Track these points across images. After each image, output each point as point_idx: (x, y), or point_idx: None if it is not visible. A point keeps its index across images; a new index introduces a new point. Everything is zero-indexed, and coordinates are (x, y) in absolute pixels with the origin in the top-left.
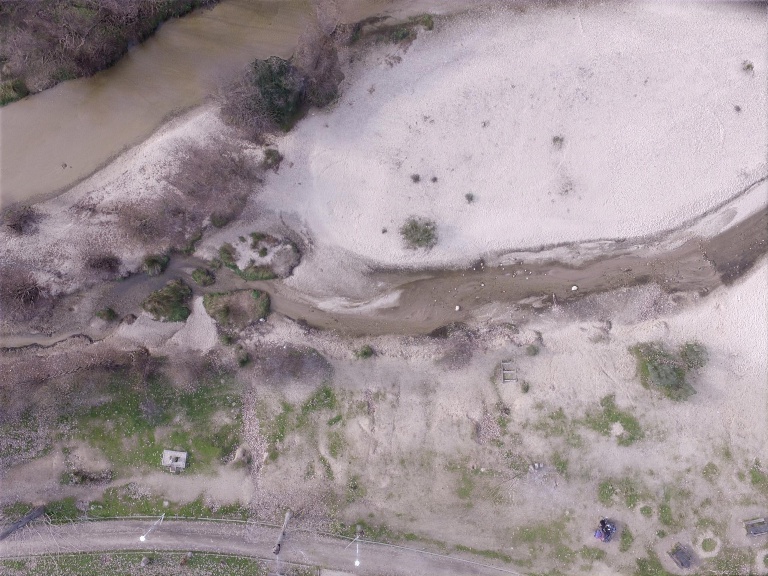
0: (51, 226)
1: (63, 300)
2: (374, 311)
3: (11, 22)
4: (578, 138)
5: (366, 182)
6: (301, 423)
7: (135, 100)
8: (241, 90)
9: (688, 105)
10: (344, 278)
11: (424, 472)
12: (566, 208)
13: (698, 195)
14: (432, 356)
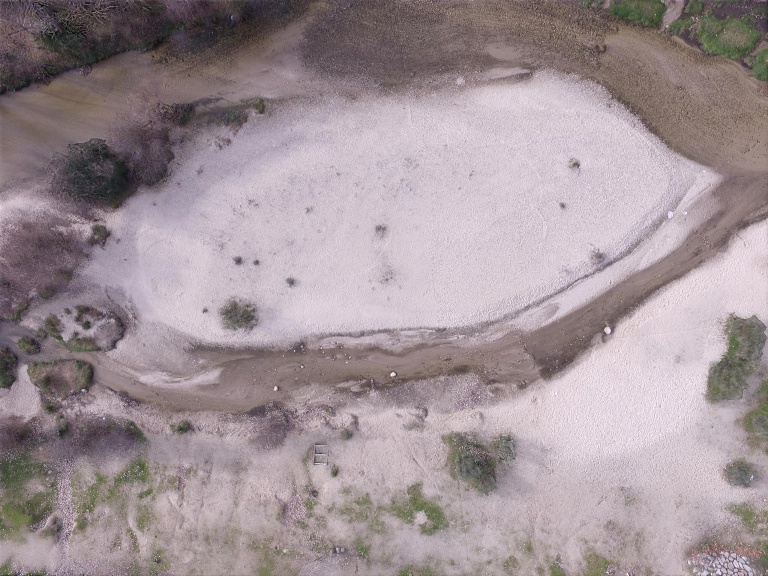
0: None
1: None
2: (194, 387)
3: None
4: (400, 228)
5: (189, 261)
6: (112, 495)
7: None
8: None
9: (512, 200)
10: (166, 353)
11: (228, 550)
12: (386, 296)
13: (518, 290)
14: (248, 434)
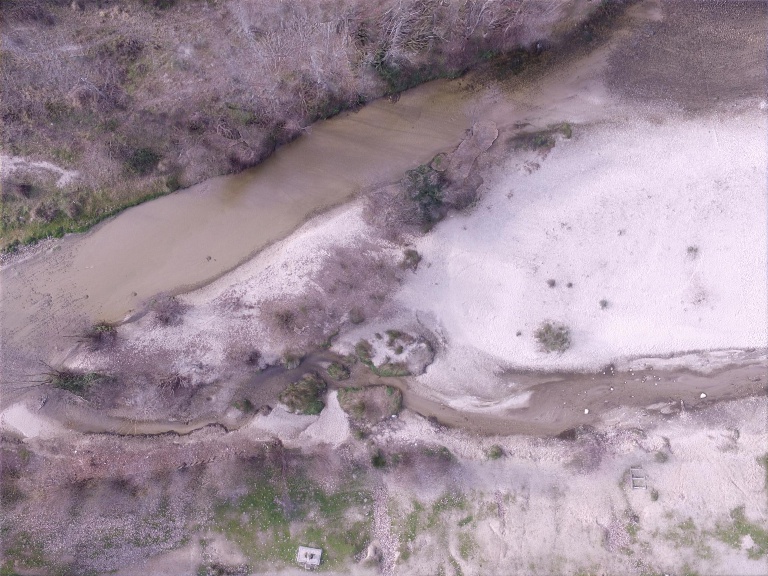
0: (195, 317)
1: (202, 389)
2: (504, 411)
3: (168, 121)
4: (712, 249)
5: (502, 285)
6: (432, 523)
7: (280, 197)
8: (382, 191)
9: None
10: (476, 378)
11: None
12: (698, 317)
13: None
14: (561, 459)
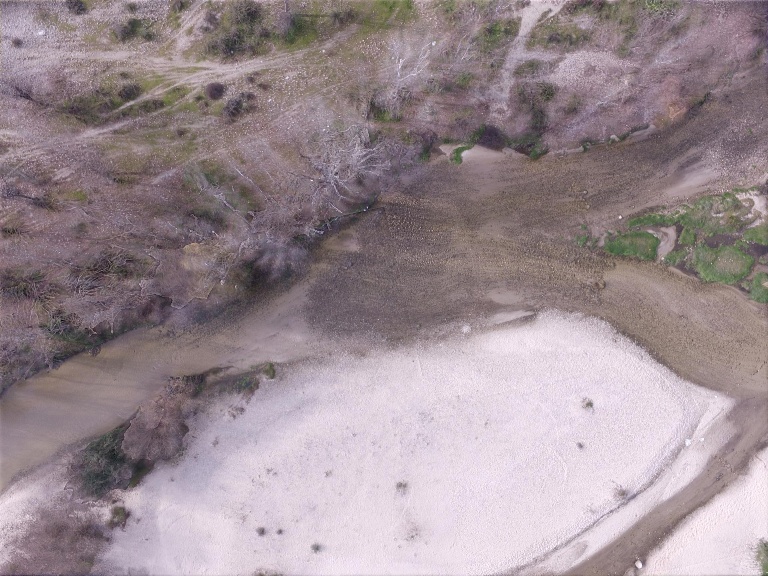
0: None
1: None
2: None
3: None
4: (421, 483)
5: (212, 536)
6: None
7: None
8: None
9: (530, 445)
10: None
11: None
12: (413, 553)
13: (545, 534)
14: None
